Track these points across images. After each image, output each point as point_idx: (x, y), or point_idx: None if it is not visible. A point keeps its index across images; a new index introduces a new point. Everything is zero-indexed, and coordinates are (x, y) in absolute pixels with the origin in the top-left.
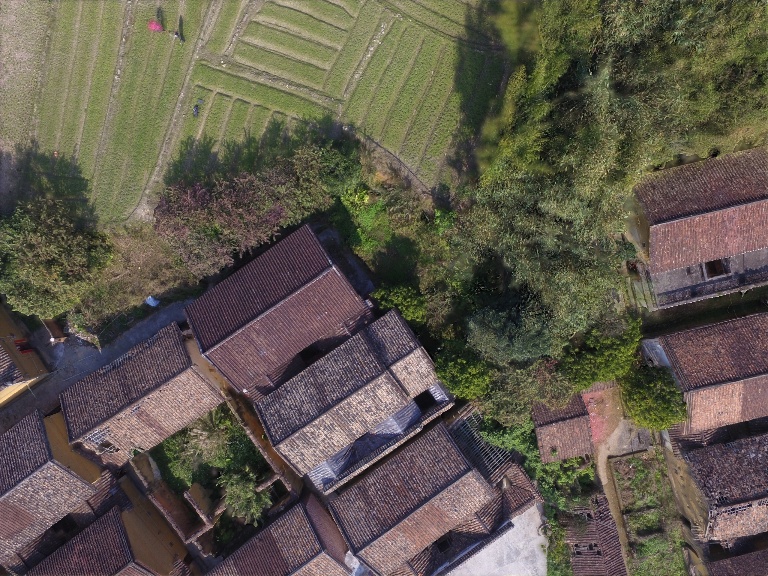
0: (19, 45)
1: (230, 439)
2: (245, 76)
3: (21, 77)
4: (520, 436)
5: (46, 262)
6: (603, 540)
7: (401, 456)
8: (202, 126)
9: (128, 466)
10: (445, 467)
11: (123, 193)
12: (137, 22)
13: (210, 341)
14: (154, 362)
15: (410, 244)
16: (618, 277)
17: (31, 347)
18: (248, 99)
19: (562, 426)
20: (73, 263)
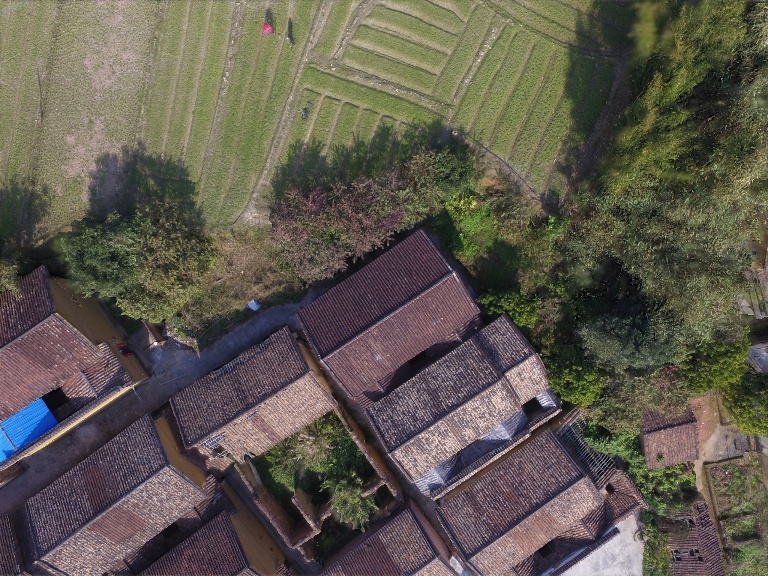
0: (126, 46)
1: (332, 444)
2: (354, 80)
3: (128, 78)
4: (624, 442)
5: (163, 266)
6: (704, 546)
7: (509, 462)
8: (310, 130)
9: (225, 470)
10: (556, 473)
11: (231, 196)
12: (246, 24)
13: (328, 347)
14: (268, 367)
15: (511, 249)
16: (747, 286)
17: (130, 350)
18: (357, 103)
19: (670, 433)
20: (187, 267)
